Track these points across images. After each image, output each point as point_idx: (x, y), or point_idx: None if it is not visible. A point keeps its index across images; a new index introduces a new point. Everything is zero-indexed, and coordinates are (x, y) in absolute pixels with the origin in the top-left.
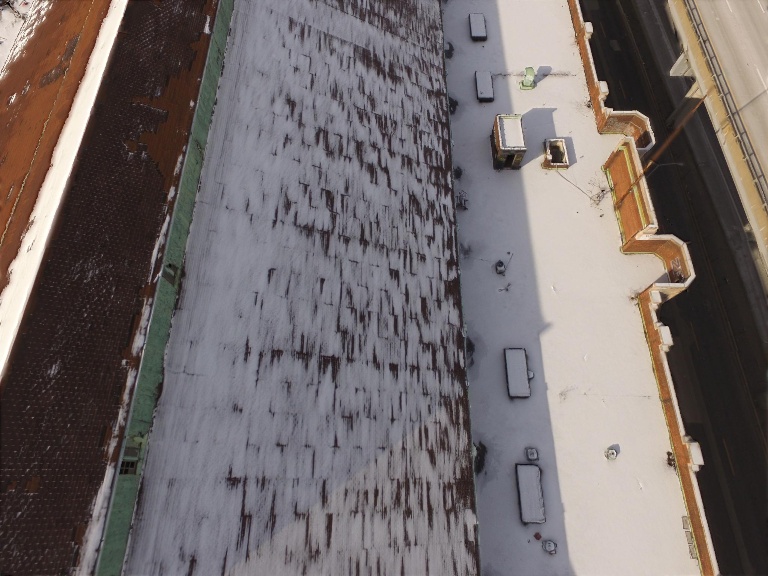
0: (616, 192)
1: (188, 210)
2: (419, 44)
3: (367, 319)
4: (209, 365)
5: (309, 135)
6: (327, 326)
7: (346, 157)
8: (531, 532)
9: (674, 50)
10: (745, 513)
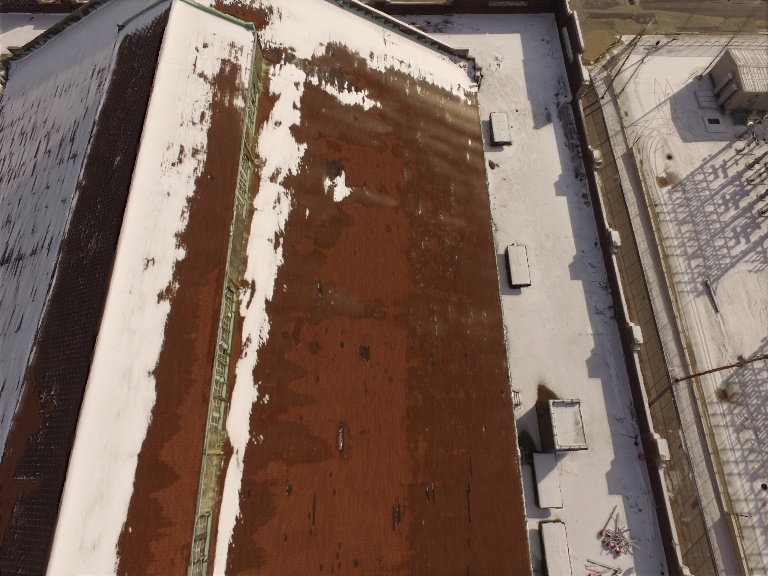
0: None
1: None
2: None
3: None
4: None
5: None
6: None
7: None
8: None
9: None
10: None
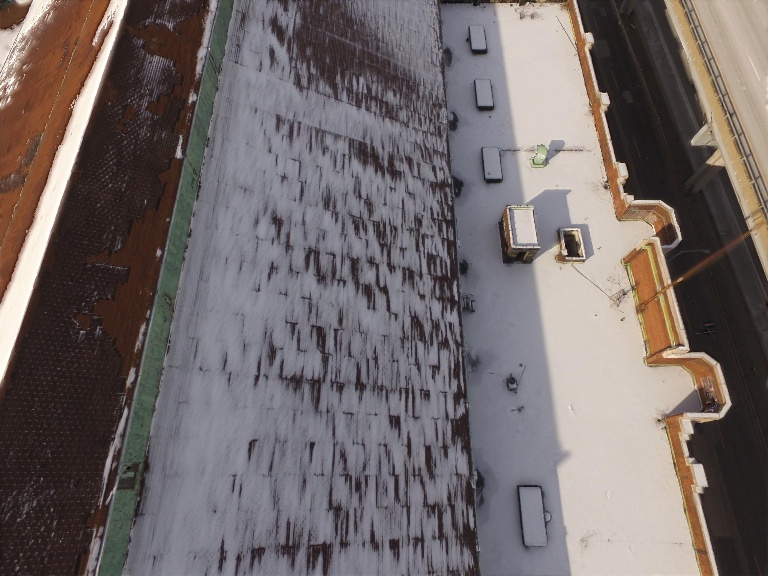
0: (638, 292)
1: (153, 383)
2: (421, 128)
3: (364, 486)
4: None
5: (298, 259)
6: (317, 504)
7: (340, 281)
8: None
9: (691, 103)
10: None
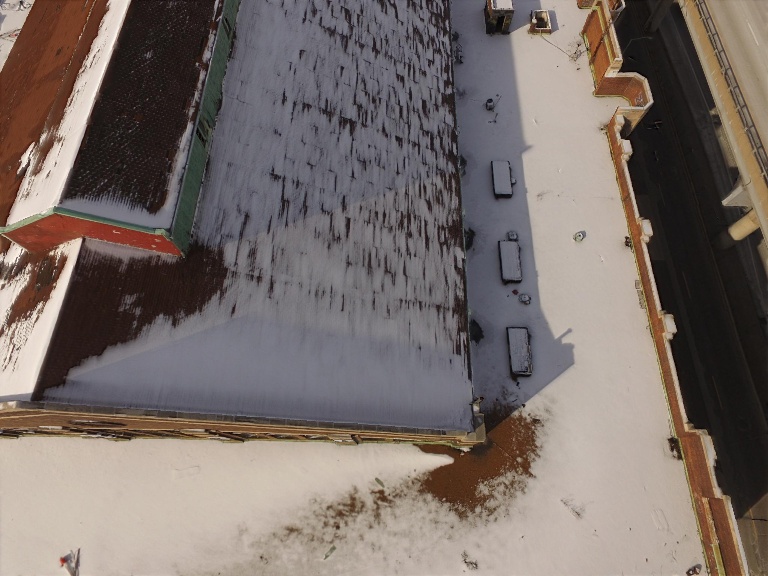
0: (591, 50)
1: None
2: None
3: (378, 102)
4: (256, 100)
5: None
6: (346, 99)
7: None
8: (510, 289)
9: None
10: (698, 326)
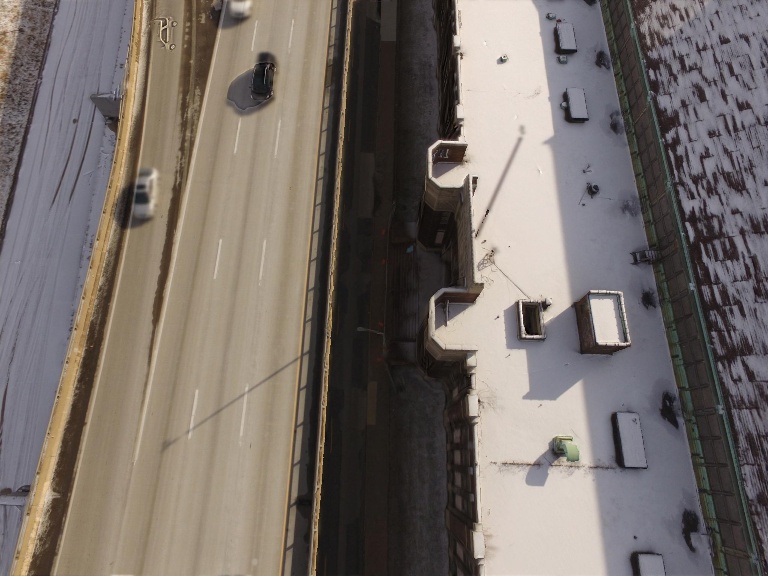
0: None
1: None
2: None
3: (765, 61)
4: None
5: None
6: None
7: None
8: None
9: None
10: (351, 99)
